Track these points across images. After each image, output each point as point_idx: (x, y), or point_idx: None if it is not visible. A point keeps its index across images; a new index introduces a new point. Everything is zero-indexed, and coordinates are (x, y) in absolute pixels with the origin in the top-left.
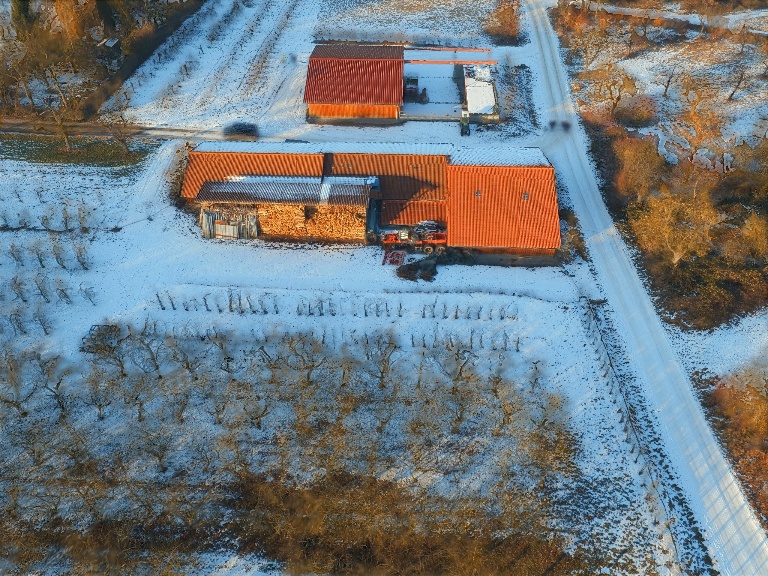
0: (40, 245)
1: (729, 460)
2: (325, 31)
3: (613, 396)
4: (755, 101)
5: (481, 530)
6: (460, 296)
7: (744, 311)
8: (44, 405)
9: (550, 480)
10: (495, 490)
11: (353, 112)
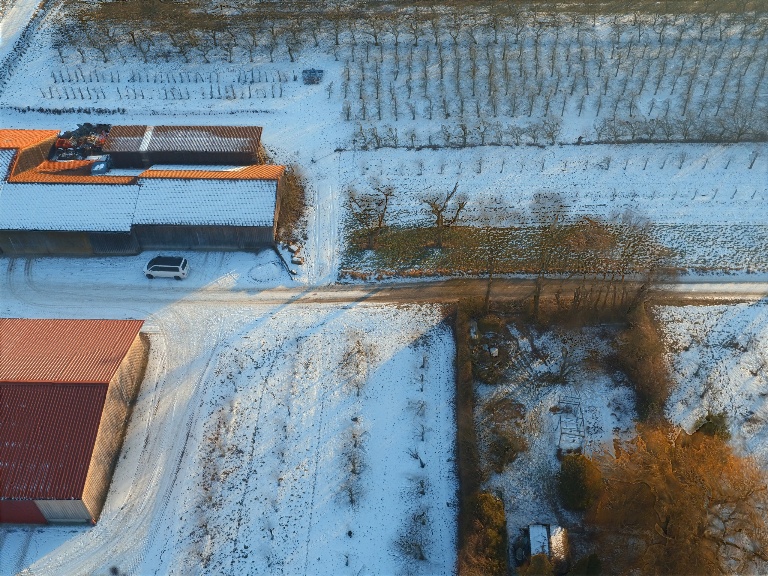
0: None
1: None
2: None
3: None
4: None
5: None
6: None
7: None
8: None
9: None
10: None
11: None
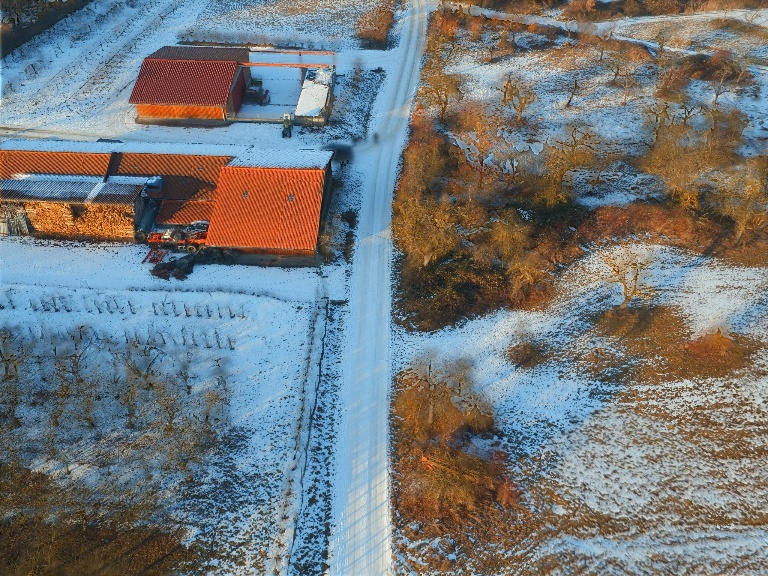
0: None
1: (391, 458)
2: (197, 32)
3: (301, 394)
4: (592, 108)
5: (110, 521)
6: (199, 295)
7: (474, 314)
8: None
9: (200, 474)
10: (142, 483)
11: (181, 113)
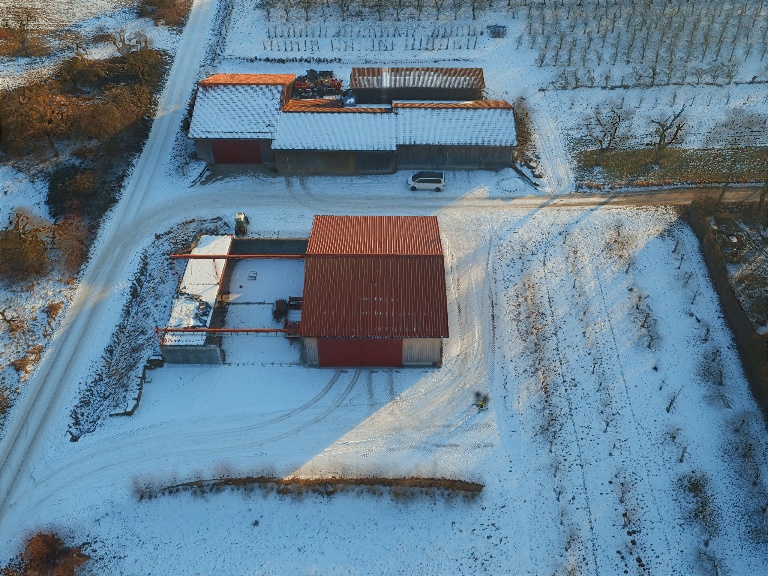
0: (586, 78)
1: (191, 8)
2: None
3: None
4: None
5: None
6: None
7: None
8: (503, 8)
9: None
10: None
11: None
